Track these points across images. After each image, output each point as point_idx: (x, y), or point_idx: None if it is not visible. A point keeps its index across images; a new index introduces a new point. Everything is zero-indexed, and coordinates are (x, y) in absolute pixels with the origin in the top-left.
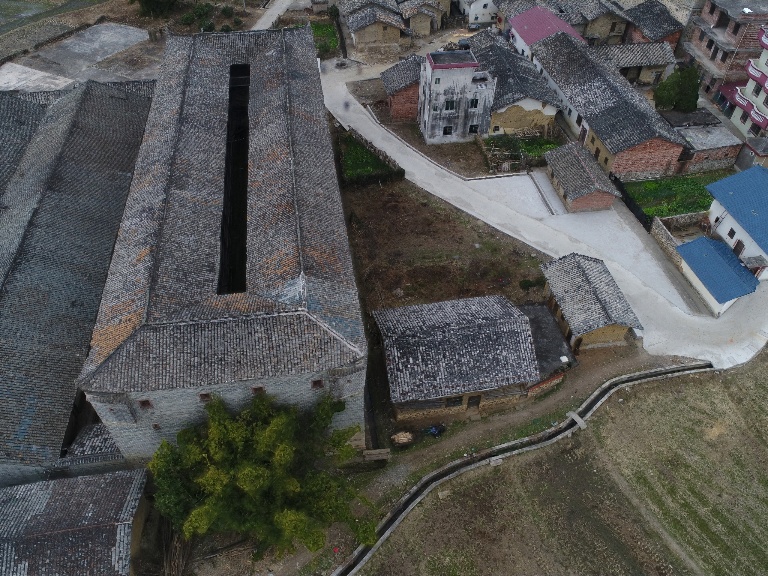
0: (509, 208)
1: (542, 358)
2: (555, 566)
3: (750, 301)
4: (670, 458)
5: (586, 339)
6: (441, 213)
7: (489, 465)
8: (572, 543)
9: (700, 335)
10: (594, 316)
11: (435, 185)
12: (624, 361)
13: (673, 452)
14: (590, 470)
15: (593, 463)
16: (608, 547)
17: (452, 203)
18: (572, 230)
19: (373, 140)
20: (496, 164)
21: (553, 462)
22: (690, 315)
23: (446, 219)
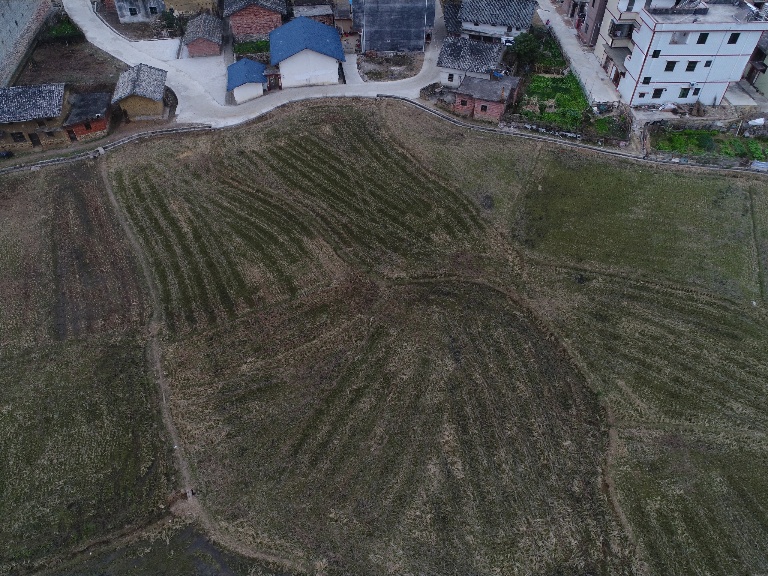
0: (149, 55)
1: (84, 114)
2: (36, 207)
3: (267, 98)
4: (145, 165)
5: (130, 111)
6: (100, 59)
7: (30, 170)
8: (54, 199)
9: (217, 113)
10: (126, 92)
11: (106, 44)
12: (157, 126)
13: (150, 163)
14: (92, 172)
15: (97, 169)
16: (75, 200)
17: (110, 53)
18: (183, 66)
19: (82, 21)
20: (157, 31)
21: (72, 169)
22: (221, 105)
23: (101, 62)
